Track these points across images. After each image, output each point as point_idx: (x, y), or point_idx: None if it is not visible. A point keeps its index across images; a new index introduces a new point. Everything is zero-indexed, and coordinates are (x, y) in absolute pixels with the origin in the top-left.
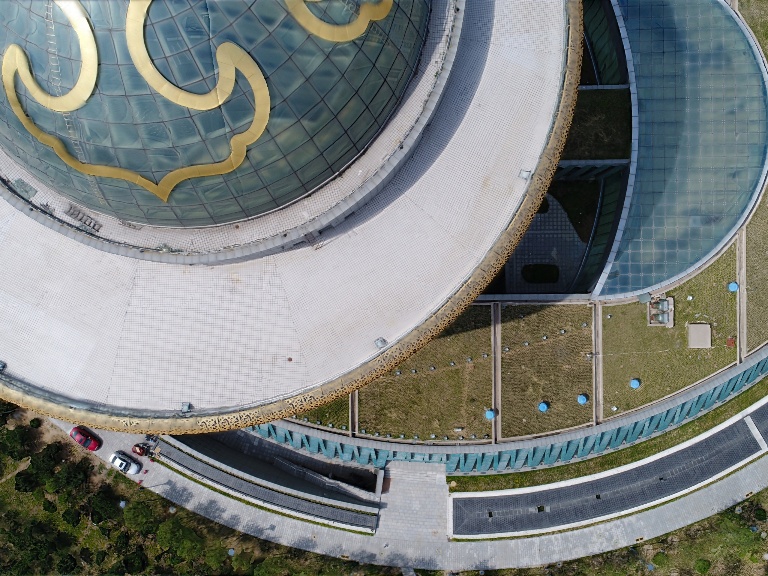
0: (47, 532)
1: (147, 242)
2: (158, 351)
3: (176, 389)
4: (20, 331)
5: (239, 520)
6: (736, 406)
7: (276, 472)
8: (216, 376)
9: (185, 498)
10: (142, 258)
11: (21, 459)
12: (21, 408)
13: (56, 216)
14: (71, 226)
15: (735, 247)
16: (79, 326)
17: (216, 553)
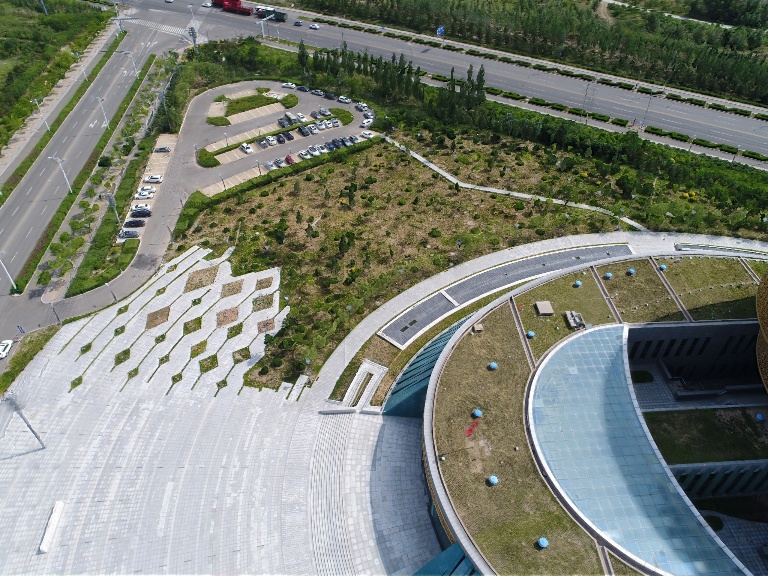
0: None
1: None
2: None
3: None
4: None
5: (761, 245)
6: (466, 311)
7: None
8: None
9: None
10: None
11: None
12: None
13: None
14: None
15: (535, 359)
16: None
17: None
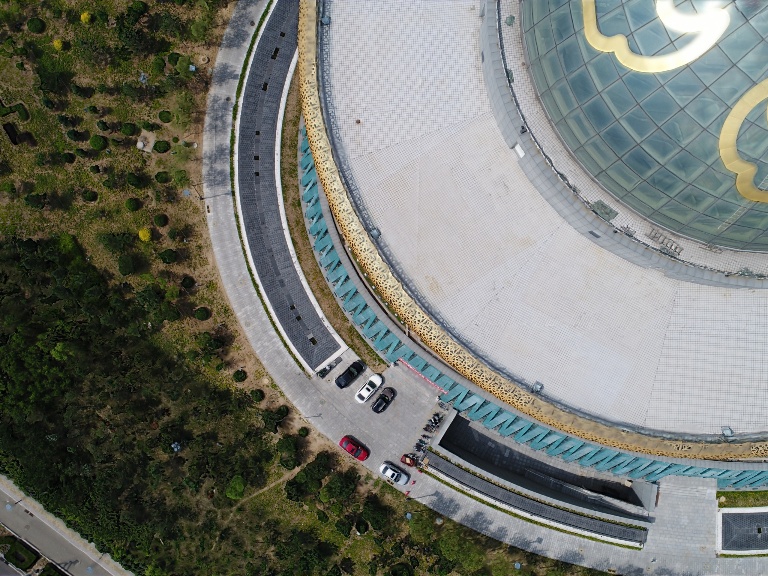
0: (307, 541)
1: (728, 266)
2: (697, 374)
3: (715, 413)
4: (557, 352)
5: (506, 532)
6: None
7: (535, 484)
8: (755, 400)
9: (452, 509)
10: (727, 282)
11: (293, 468)
12: (288, 417)
13: (637, 238)
14: (656, 249)
15: None
16: (617, 348)
17: (503, 566)
